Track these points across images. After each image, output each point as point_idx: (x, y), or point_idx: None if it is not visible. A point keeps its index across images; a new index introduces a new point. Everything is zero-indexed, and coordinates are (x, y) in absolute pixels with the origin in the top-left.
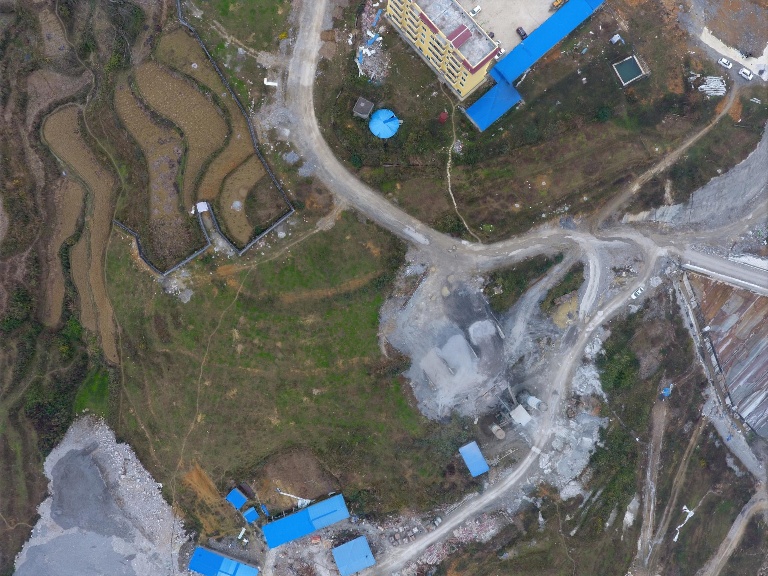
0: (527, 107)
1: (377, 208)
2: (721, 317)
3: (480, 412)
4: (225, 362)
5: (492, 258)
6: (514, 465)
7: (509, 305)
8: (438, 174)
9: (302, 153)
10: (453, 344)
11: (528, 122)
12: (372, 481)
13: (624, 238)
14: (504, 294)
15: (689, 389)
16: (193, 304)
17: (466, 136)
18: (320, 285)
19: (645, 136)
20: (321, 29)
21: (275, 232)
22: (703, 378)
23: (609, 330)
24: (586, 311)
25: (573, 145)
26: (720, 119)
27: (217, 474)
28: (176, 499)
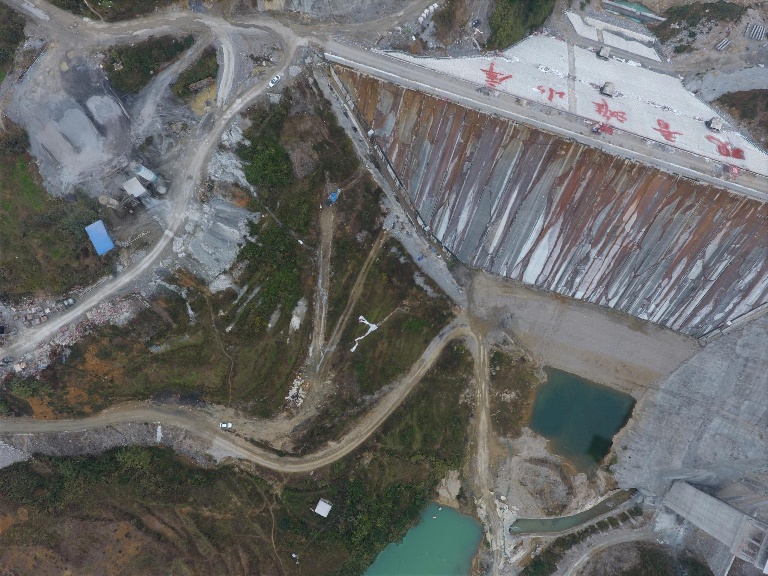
0: None
1: None
2: (380, 118)
3: (113, 195)
4: None
5: (115, 36)
6: (147, 248)
7: (136, 85)
8: None
9: None
10: (74, 120)
11: None
12: (3, 261)
13: (262, 26)
14: (122, 69)
15: (355, 194)
16: None
17: None
18: None
19: None
20: None
21: None
22: (369, 183)
23: (248, 118)
24: (224, 99)
25: None
26: None
27: None
28: None
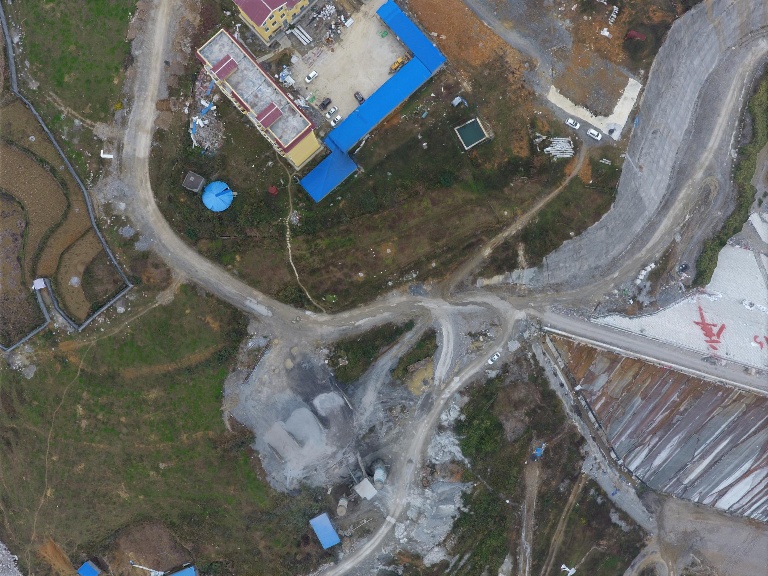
0: (366, 175)
1: (217, 281)
2: (591, 377)
3: (333, 482)
4: (70, 438)
5: (337, 328)
6: (369, 535)
7: (358, 375)
8: (277, 245)
9: (138, 227)
10: (299, 416)
11: (365, 191)
12: (225, 553)
13: (479, 302)
14: (348, 366)
15: (561, 449)
16: (37, 380)
17: (303, 206)
18: (160, 360)
19: (494, 199)
20: (156, 98)
21: (114, 307)
22: (576, 438)
23: (466, 396)
24: (442, 377)
25: (418, 211)
26: (570, 181)
27: (70, 547)
28: (31, 571)
